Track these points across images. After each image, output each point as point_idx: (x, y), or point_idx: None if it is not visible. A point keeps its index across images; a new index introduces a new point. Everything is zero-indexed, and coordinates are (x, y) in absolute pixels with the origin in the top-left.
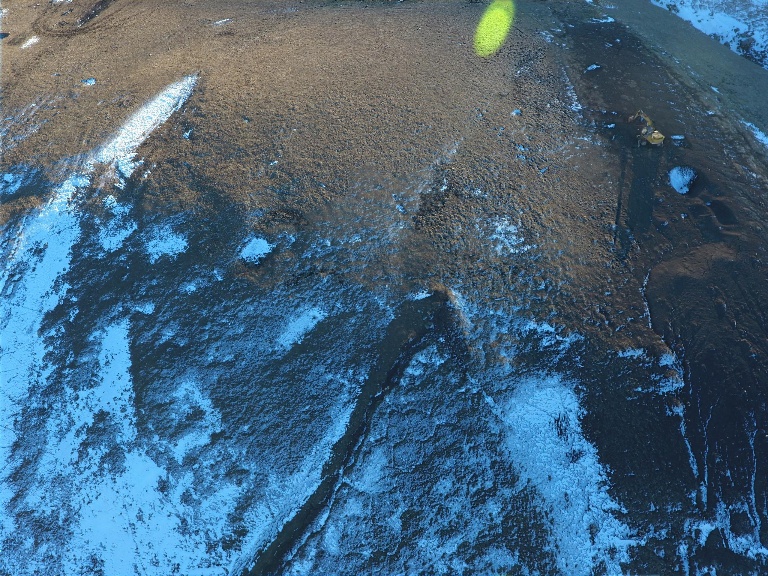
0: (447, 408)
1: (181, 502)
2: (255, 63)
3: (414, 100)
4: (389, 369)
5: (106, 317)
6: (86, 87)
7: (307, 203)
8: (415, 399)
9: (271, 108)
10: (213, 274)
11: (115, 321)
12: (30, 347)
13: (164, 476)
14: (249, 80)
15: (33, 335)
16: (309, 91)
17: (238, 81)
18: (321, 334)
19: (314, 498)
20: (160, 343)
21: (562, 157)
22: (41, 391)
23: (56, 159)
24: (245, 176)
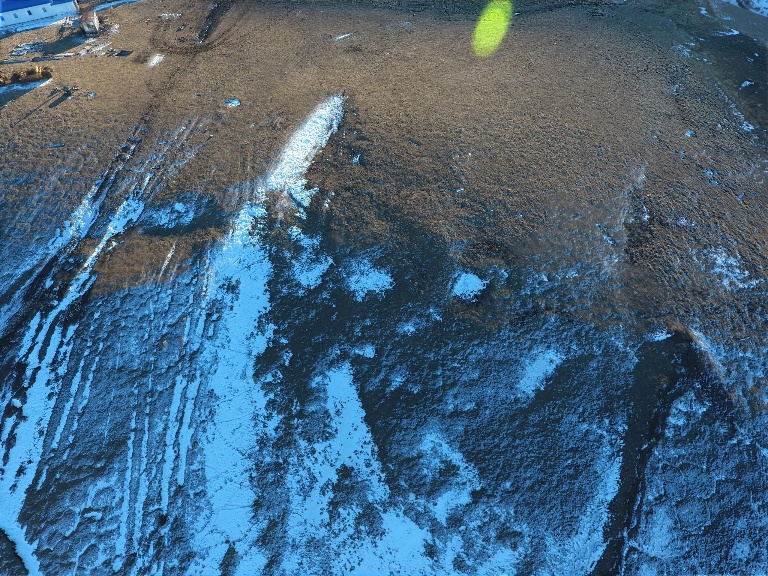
0: (723, 462)
1: (454, 569)
2: (399, 81)
3: (583, 121)
4: (649, 418)
5: (324, 361)
6: (232, 108)
7: (509, 234)
8: (686, 452)
9: (437, 130)
10: (430, 313)
11: (335, 365)
12: (248, 394)
13: (430, 539)
14: (402, 100)
15: (249, 381)
16: (470, 112)
17: (390, 101)
18: (564, 379)
19: (602, 564)
20: (391, 390)
21: (755, 182)
22: (272, 443)
23: (225, 187)
24: (434, 205)
